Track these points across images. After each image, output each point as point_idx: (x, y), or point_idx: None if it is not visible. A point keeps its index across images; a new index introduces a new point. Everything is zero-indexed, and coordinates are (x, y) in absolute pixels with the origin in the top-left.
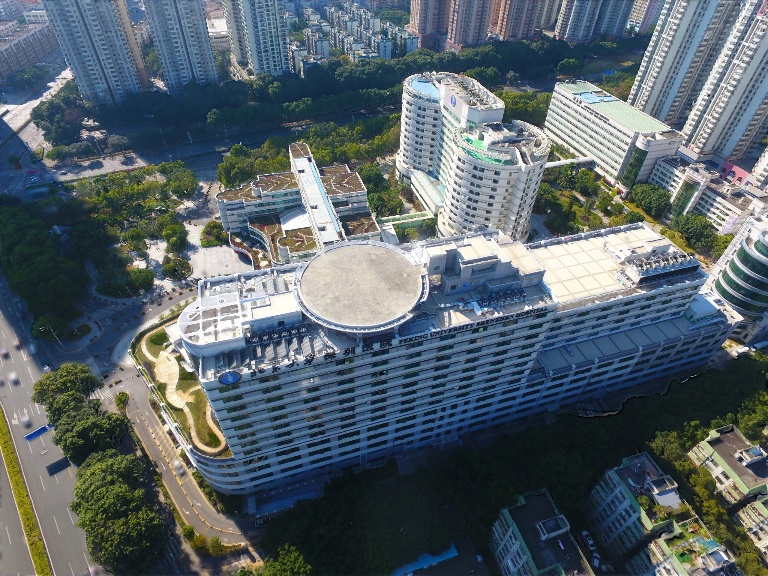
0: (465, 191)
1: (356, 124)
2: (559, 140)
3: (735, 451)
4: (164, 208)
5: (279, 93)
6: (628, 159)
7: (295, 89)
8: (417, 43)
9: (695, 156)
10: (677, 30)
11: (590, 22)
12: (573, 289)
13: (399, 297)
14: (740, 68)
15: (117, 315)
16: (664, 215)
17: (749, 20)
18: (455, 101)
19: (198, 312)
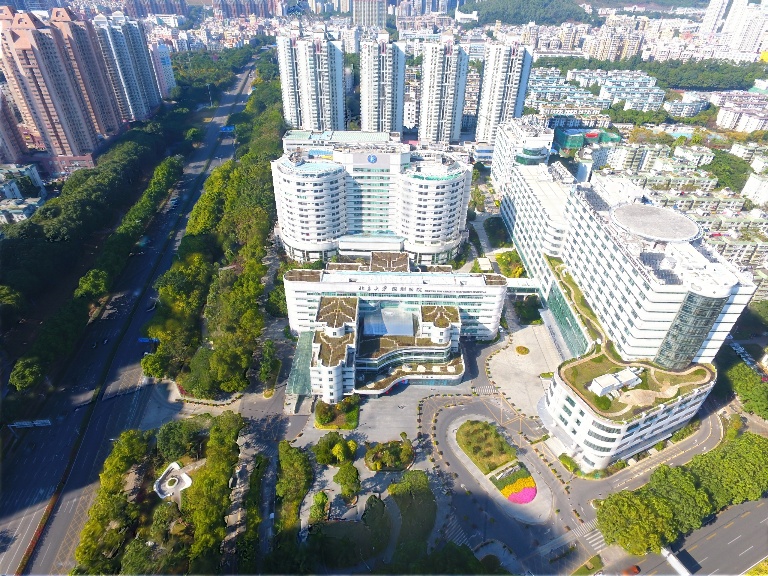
0: (447, 207)
1: (183, 258)
2: None
3: None
4: None
5: (22, 296)
6: None
7: (31, 280)
8: (36, 172)
9: None
10: None
11: (145, 98)
12: None
13: (665, 213)
14: (389, 86)
15: (468, 523)
16: None
17: (378, 58)
18: (376, 158)
19: None
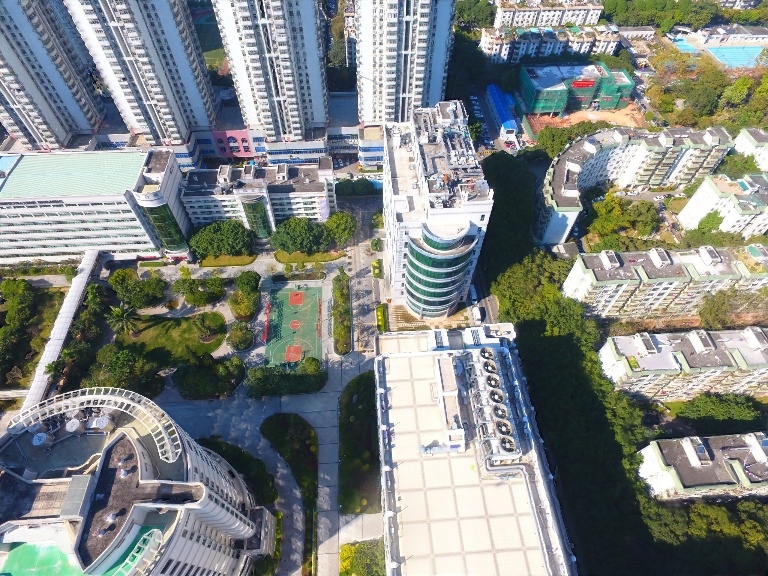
0: None
1: None
2: (7, 260)
3: (686, 461)
4: None
5: None
6: (147, 223)
7: None
8: None
9: (183, 149)
10: None
11: None
12: (521, 575)
13: None
14: (130, 31)
15: None
16: (255, 244)
17: None
18: None
19: None
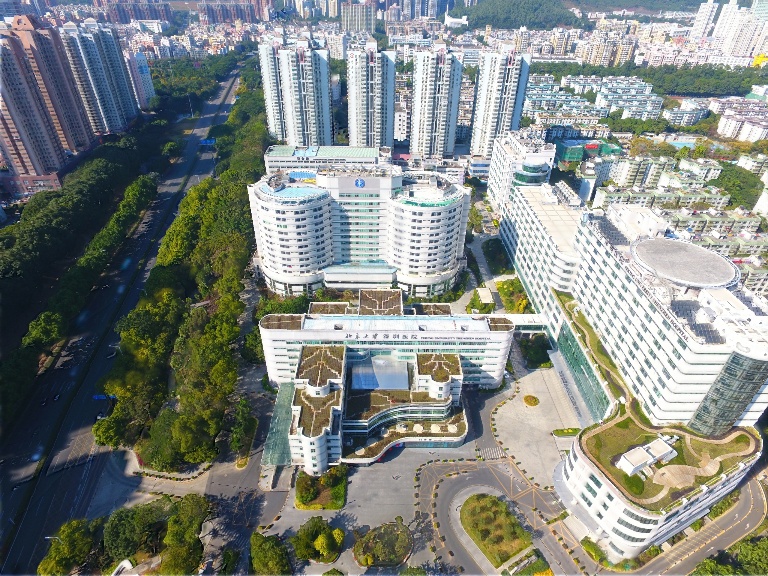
0: (444, 235)
1: (150, 294)
2: None
3: None
4: (202, 569)
5: None
6: None
7: None
8: None
9: None
10: (313, 87)
11: (120, 110)
12: None
13: (694, 250)
14: (378, 97)
15: None
16: None
17: (366, 68)
18: (364, 182)
19: (738, 349)
